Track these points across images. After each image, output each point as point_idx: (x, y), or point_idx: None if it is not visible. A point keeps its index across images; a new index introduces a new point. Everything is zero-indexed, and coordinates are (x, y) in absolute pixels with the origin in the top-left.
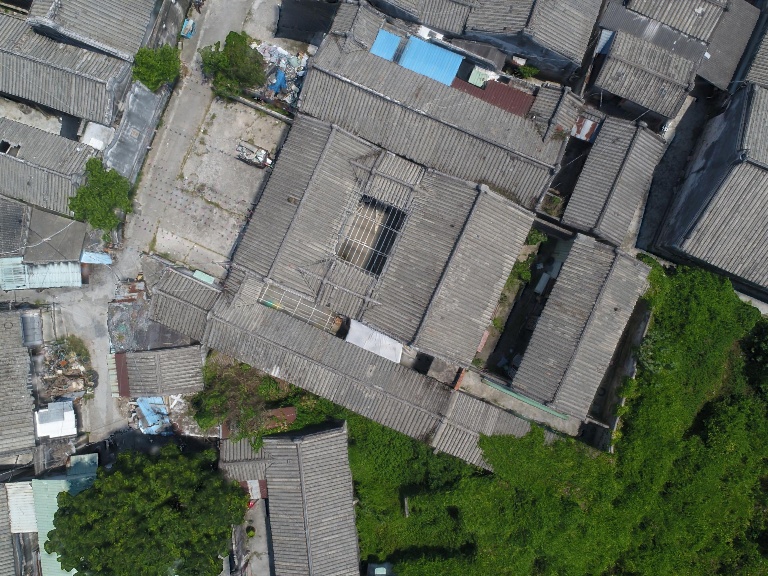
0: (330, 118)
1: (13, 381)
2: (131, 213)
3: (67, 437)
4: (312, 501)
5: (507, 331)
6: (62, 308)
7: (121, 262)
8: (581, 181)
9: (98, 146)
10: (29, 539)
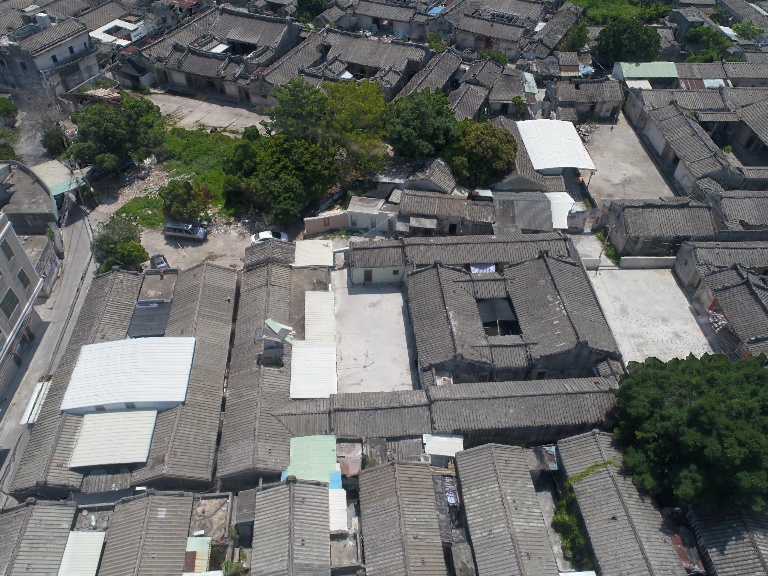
0: None
1: None
2: None
3: None
4: None
5: None
6: None
7: None
8: None
9: None
10: None
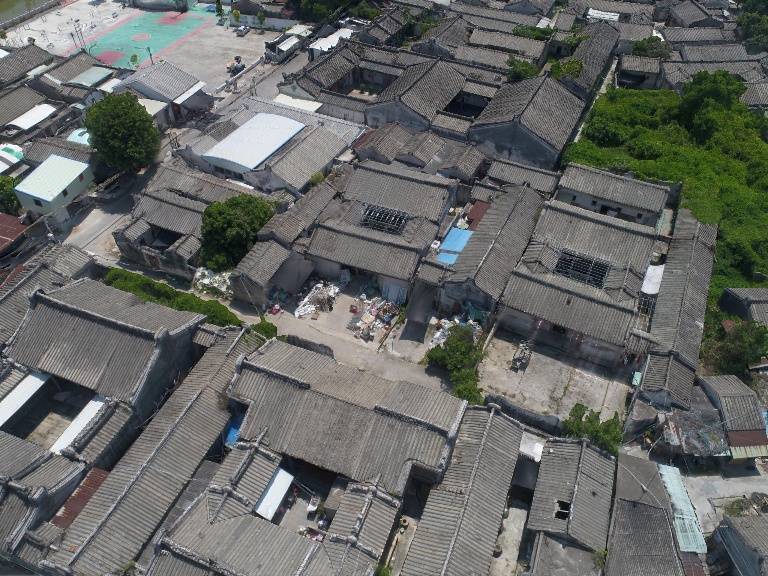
0: (502, 284)
1: None
2: None
3: None
4: None
5: None
6: None
7: None
8: None
9: (540, 448)
10: None
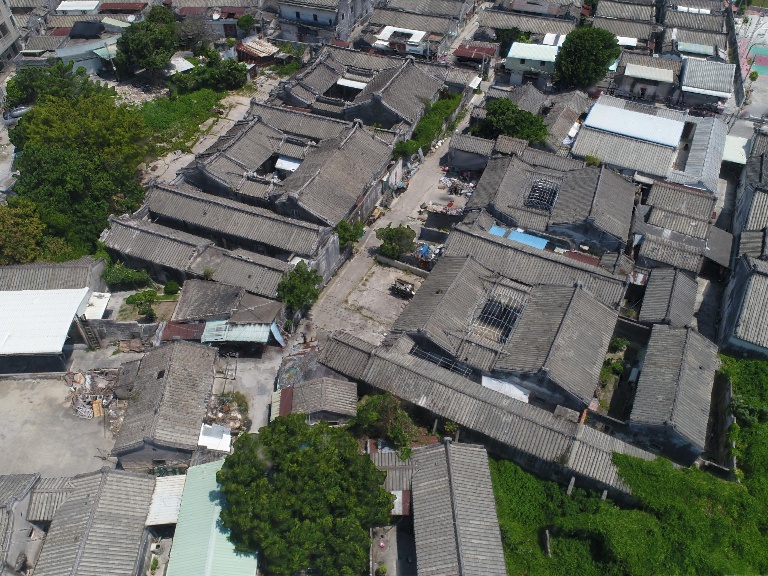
0: None
1: (195, 393)
2: (304, 319)
3: (221, 452)
4: (460, 499)
5: (612, 409)
6: (234, 373)
7: (291, 346)
8: (646, 299)
9: None
10: (144, 558)
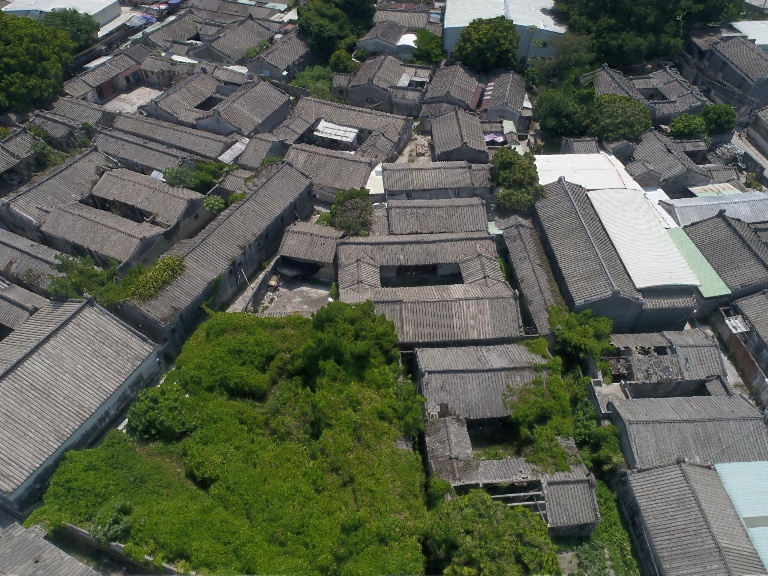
0: None
1: None
2: None
3: None
4: None
5: None
6: None
7: None
8: None
9: None
10: None
